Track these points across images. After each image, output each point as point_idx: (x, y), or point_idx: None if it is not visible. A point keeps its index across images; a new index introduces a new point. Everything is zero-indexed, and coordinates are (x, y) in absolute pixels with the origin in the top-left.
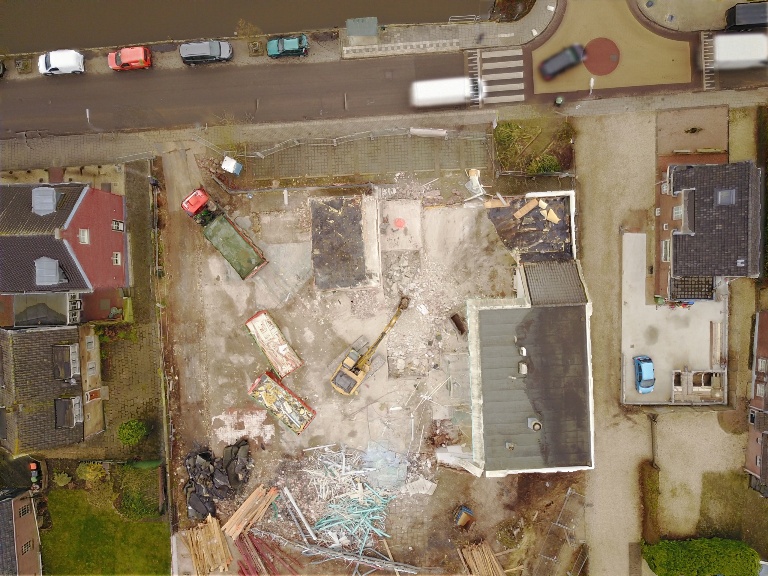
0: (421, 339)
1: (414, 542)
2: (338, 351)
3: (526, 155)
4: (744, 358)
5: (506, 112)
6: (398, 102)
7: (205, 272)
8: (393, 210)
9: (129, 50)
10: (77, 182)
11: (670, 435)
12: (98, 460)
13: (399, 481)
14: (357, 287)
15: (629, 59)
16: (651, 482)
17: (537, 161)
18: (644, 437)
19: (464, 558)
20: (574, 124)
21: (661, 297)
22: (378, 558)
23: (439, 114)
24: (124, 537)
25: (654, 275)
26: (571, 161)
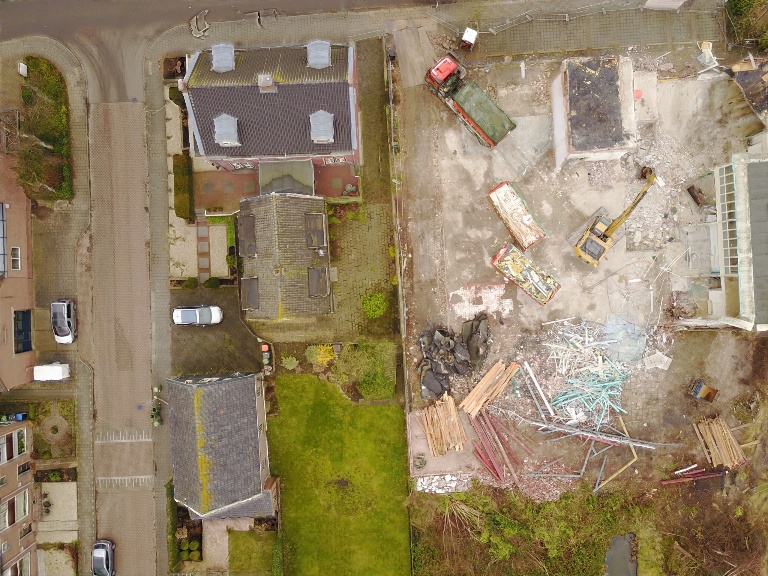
0: (658, 211)
1: (649, 418)
2: (576, 224)
3: (758, 27)
4: None
5: None
6: None
7: (442, 147)
8: None
9: None
10: (339, 44)
11: None
12: (327, 342)
13: (638, 354)
14: (614, 148)
15: None
16: None
17: None
18: None
19: (700, 433)
20: None
21: None
22: (614, 434)
23: None
24: (352, 421)
25: None
26: None
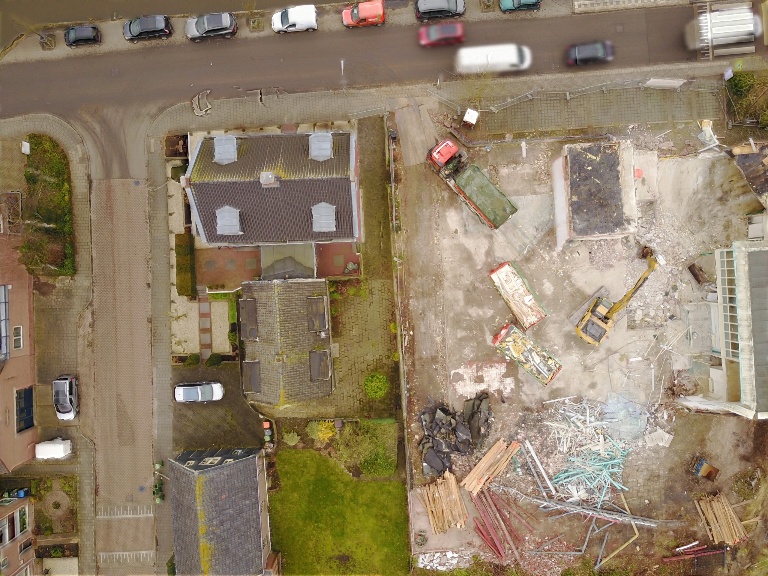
0: (659, 289)
1: (650, 495)
2: (577, 302)
3: (758, 106)
4: None
5: (737, 64)
6: (630, 55)
7: (443, 226)
8: None
9: (368, 6)
10: (340, 131)
11: None
12: (329, 418)
13: (639, 432)
14: (615, 233)
15: None
16: None
17: None
18: None
19: (702, 510)
20: None
21: None
22: (616, 511)
23: (670, 67)
24: (354, 496)
25: None
26: None
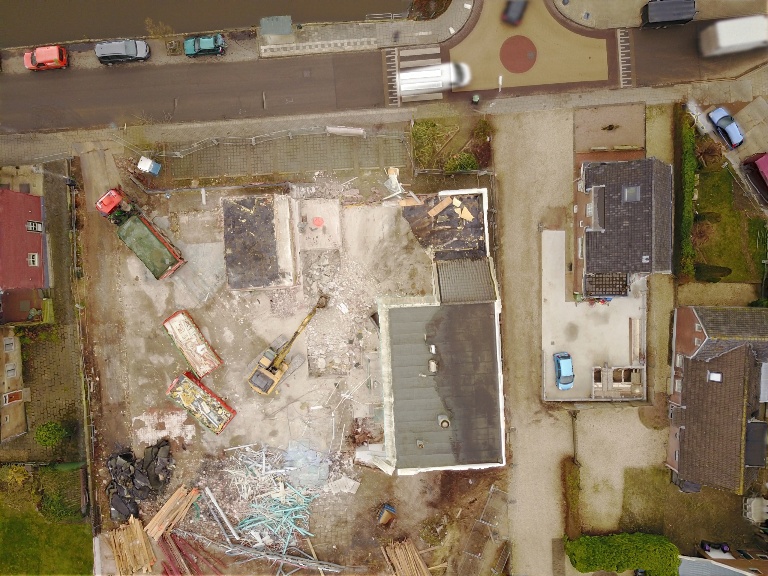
0: (341, 338)
1: (338, 541)
2: (258, 350)
3: (445, 153)
4: (663, 354)
5: (424, 110)
6: (316, 101)
7: (124, 272)
8: (311, 209)
9: (44, 50)
10: None
11: (592, 431)
12: (21, 462)
13: (321, 480)
14: (270, 286)
15: (546, 57)
16: (572, 478)
17: (454, 159)
18: (566, 433)
19: (388, 556)
20: (492, 122)
21: (579, 294)
22: (302, 557)
23: (358, 113)
24: (48, 539)
25: (573, 272)
26: (490, 159)
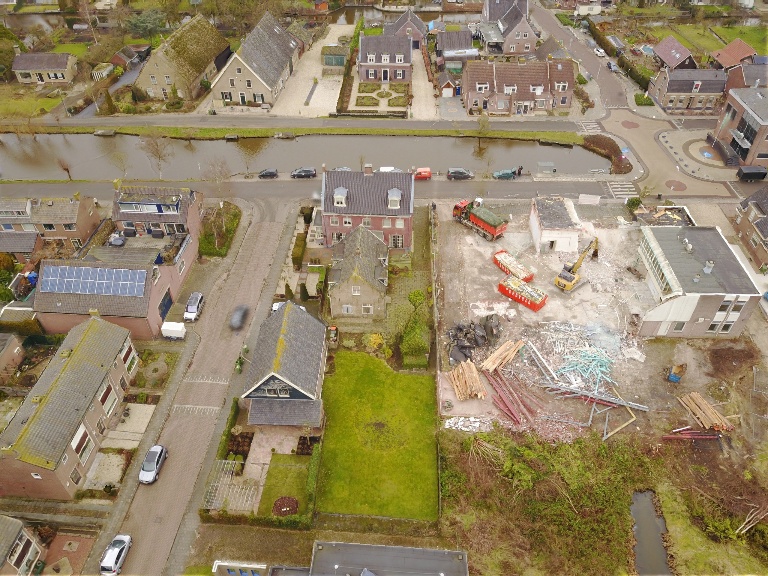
0: (610, 277)
1: (638, 392)
2: None
3: None
4: None
5: None
6: None
7: (463, 242)
8: None
9: None
10: None
11: None
12: None
13: (616, 346)
14: (569, 228)
15: (692, 187)
16: None
17: None
18: None
19: (685, 403)
20: None
21: (764, 263)
22: None
23: None
24: (393, 383)
25: (754, 261)
26: None
